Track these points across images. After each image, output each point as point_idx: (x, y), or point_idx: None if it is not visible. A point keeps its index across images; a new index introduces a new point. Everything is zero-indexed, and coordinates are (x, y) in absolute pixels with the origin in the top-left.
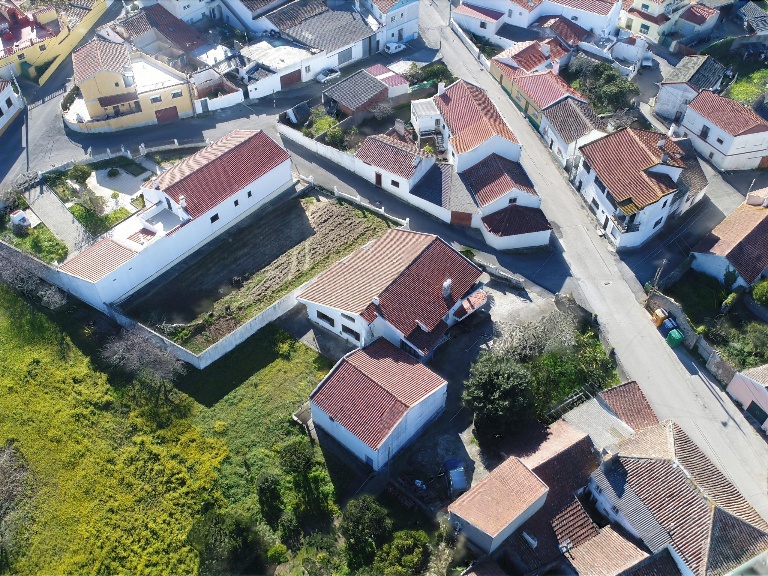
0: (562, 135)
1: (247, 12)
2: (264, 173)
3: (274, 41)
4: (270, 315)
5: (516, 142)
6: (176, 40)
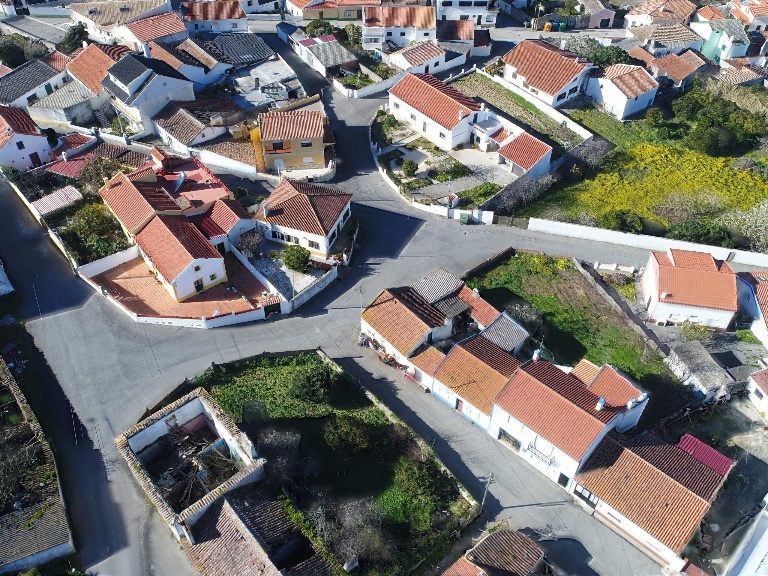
0: (412, 4)
1: (199, 71)
2: None
3: (239, 75)
4: None
5: None
6: (226, 109)
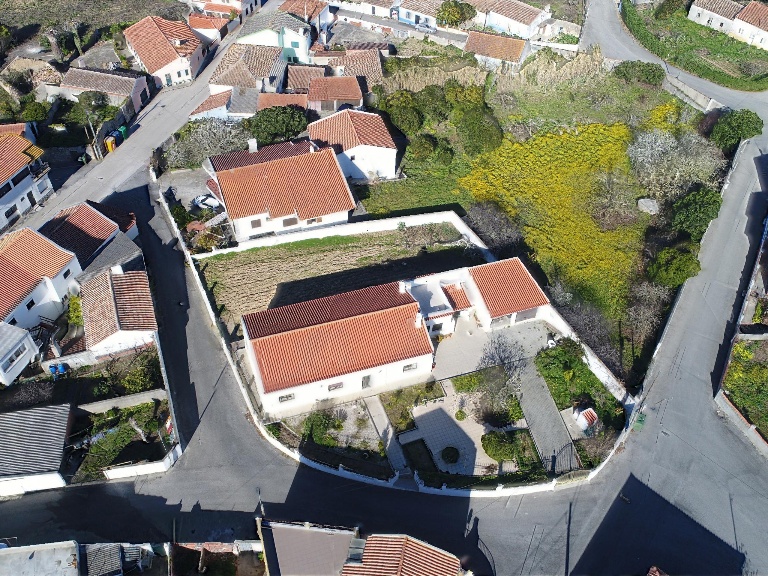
0: None
1: None
2: (291, 306)
3: None
4: (379, 227)
5: (7, 236)
6: None
